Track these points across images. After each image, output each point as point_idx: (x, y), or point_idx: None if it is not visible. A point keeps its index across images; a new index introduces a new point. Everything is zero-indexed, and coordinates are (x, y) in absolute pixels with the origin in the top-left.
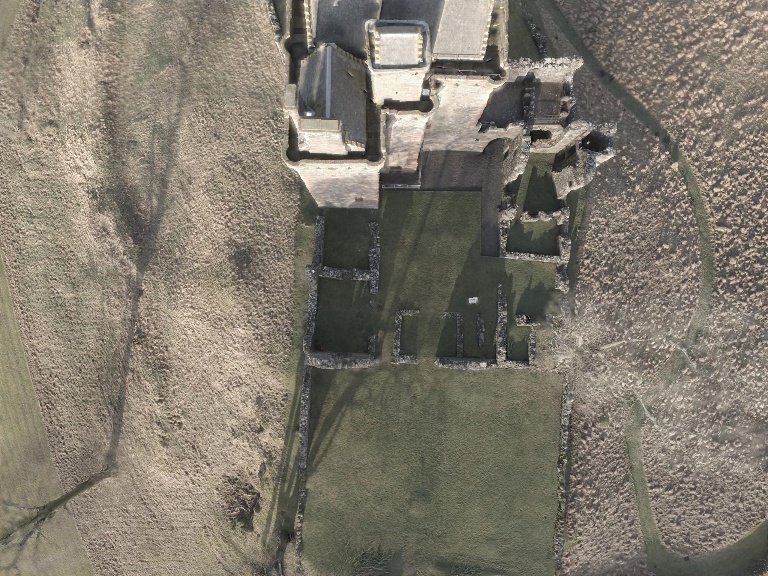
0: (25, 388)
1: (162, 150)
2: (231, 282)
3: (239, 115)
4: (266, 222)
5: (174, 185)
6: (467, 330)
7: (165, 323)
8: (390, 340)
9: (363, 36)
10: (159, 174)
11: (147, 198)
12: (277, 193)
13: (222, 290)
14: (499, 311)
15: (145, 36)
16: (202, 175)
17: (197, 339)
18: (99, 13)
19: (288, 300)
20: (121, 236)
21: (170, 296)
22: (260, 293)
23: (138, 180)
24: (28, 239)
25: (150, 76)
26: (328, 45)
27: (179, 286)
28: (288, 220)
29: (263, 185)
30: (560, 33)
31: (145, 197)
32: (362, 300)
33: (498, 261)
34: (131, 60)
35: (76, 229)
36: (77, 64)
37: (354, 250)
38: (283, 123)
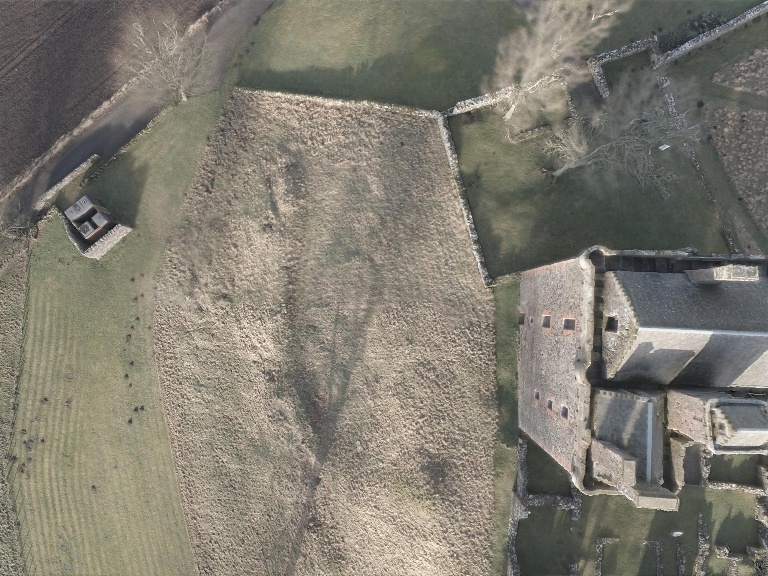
0: (183, 550)
1: (345, 341)
2: (426, 496)
3: (433, 321)
4: (462, 436)
5: (357, 378)
6: (667, 560)
7: (343, 514)
8: (591, 569)
9: (667, 371)
10: (340, 364)
11: (326, 386)
12: (474, 407)
13: (414, 500)
14: (701, 544)
15: (328, 222)
16: (391, 376)
17: (379, 538)
18: (284, 199)
19: (487, 521)
20: (300, 424)
21: (351, 490)
22: (457, 510)
23: (317, 366)
24: (194, 405)
25: (333, 264)
26: (649, 400)
27: (361, 482)
28: (486, 437)
29: (458, 397)
30: (752, 242)
31: (324, 384)
32: (562, 526)
33: (698, 489)
34: (312, 245)
35: (246, 403)
36: (258, 245)
37: (555, 474)
38: (479, 334)
